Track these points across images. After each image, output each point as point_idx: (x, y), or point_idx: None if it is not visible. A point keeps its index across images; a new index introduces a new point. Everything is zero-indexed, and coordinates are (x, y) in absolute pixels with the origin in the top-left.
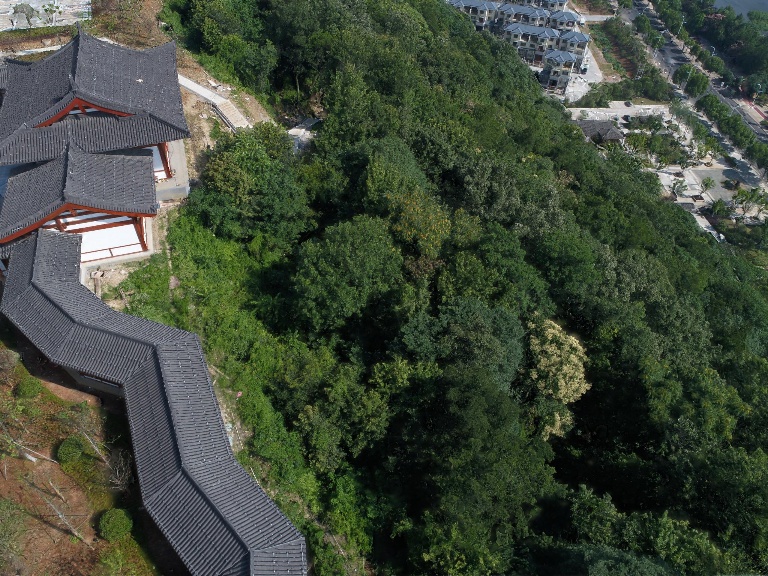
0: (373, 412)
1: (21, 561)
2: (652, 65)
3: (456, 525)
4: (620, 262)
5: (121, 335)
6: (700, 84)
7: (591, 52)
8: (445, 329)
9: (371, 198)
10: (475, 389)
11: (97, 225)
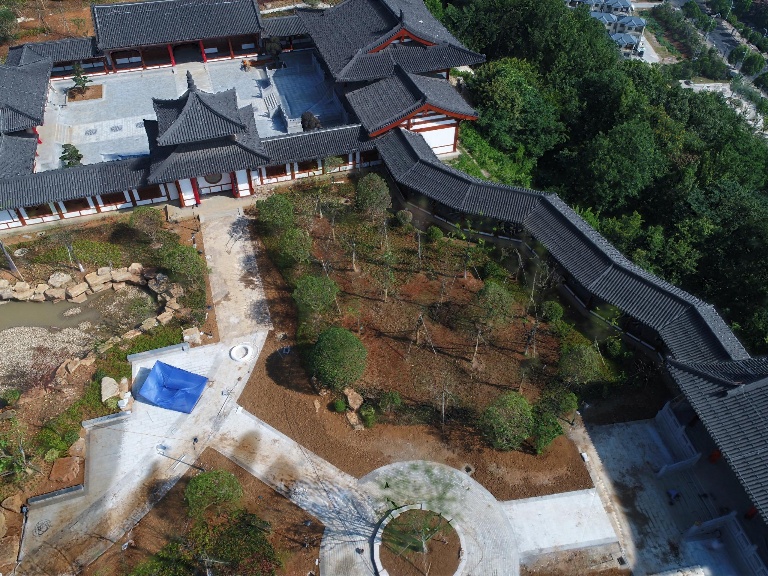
0: (683, 256)
1: (495, 332)
2: (706, 47)
3: None
4: None
5: (512, 190)
6: (757, 63)
7: (644, 36)
8: (717, 202)
9: (622, 112)
10: None
11: (432, 126)
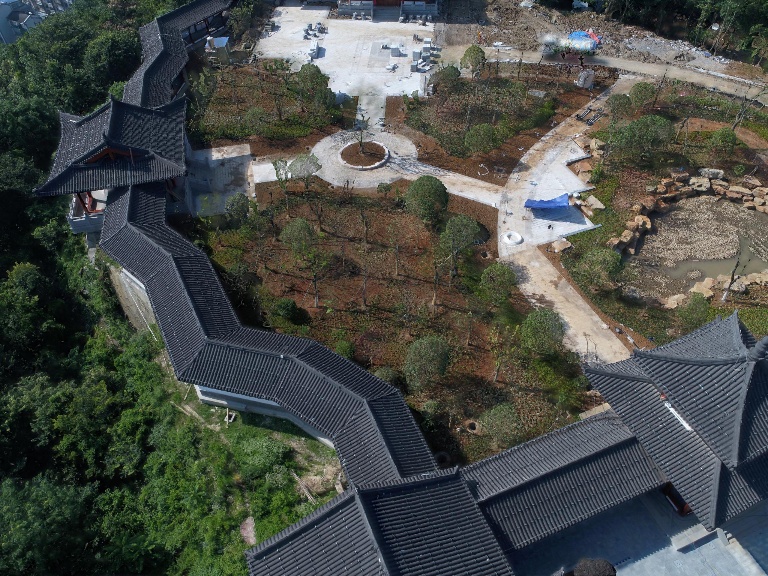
0: None
1: None
2: None
3: (1, 294)
4: None
5: None
6: None
7: None
8: None
9: None
10: None
11: None
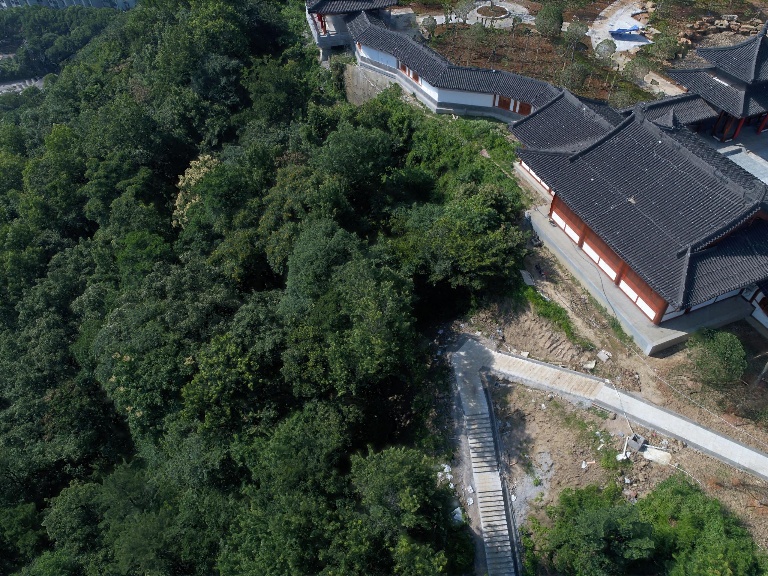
0: None
1: None
2: None
3: None
4: (54, 362)
5: None
6: None
7: None
8: None
9: None
10: None
11: None
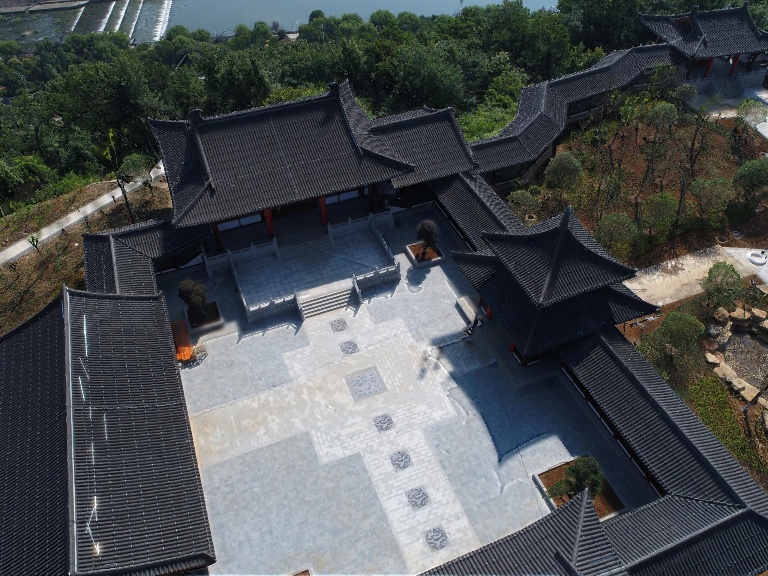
0: None
1: None
2: None
3: None
4: None
5: None
6: None
7: None
8: None
9: (363, 62)
10: (520, 24)
11: None
